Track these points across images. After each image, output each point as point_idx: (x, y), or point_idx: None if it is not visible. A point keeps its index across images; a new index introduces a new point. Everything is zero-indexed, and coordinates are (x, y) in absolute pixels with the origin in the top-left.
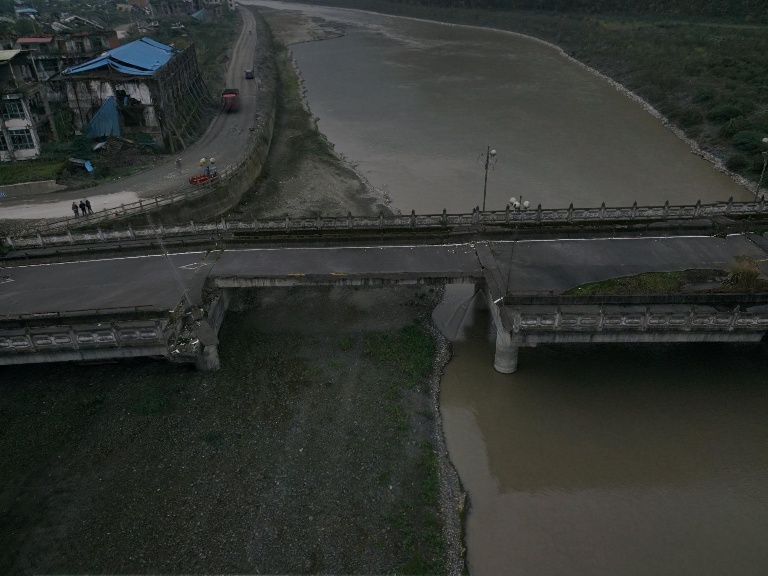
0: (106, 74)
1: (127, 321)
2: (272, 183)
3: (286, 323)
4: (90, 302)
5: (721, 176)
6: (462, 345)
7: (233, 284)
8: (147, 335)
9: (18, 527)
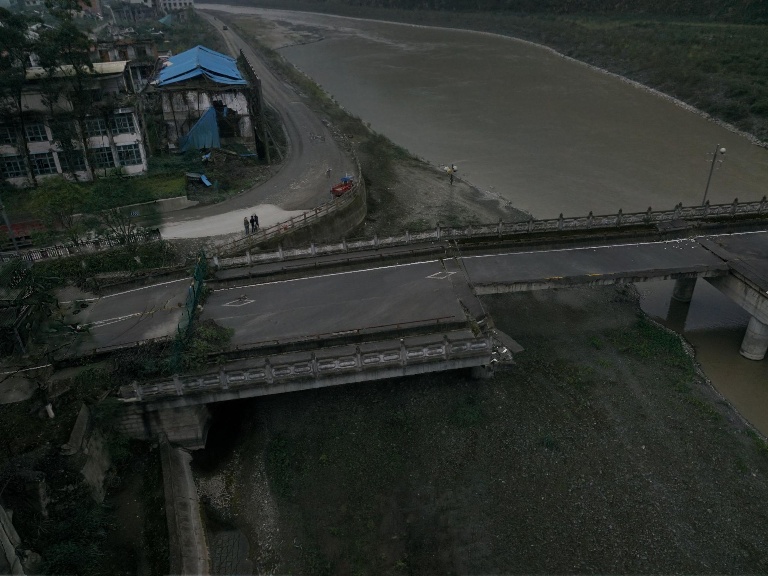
0: (199, 84)
1: (428, 334)
2: (382, 190)
3: (519, 327)
4: (366, 318)
5: None
6: (696, 336)
7: (491, 291)
8: (477, 346)
9: (434, 549)
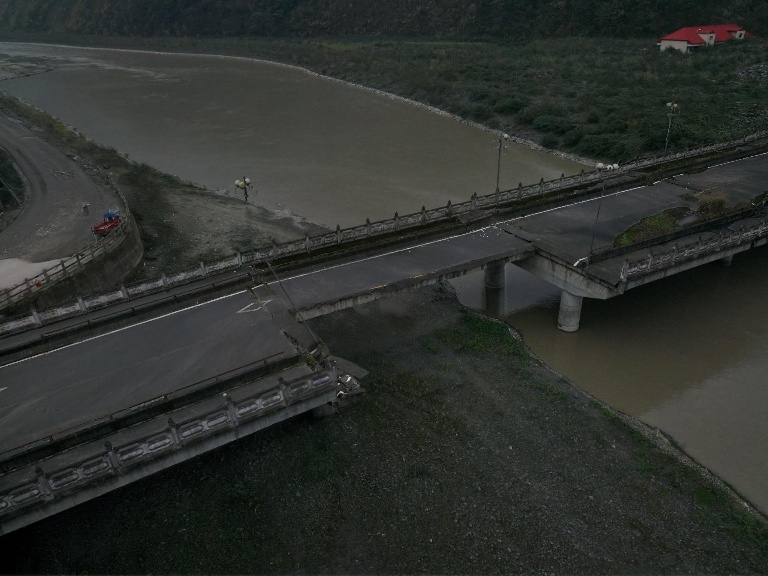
0: None
1: (257, 380)
2: (157, 223)
3: (350, 347)
4: (171, 377)
5: (541, 154)
6: (517, 320)
7: (315, 314)
8: (319, 381)
9: None
